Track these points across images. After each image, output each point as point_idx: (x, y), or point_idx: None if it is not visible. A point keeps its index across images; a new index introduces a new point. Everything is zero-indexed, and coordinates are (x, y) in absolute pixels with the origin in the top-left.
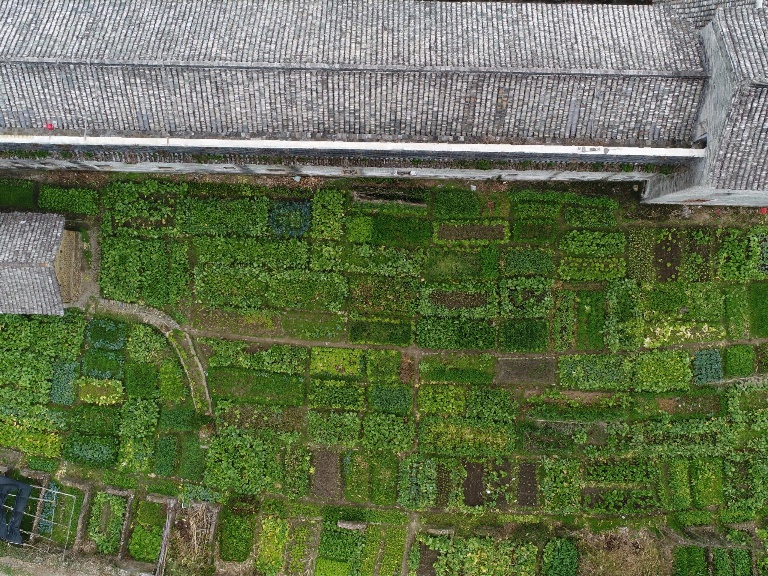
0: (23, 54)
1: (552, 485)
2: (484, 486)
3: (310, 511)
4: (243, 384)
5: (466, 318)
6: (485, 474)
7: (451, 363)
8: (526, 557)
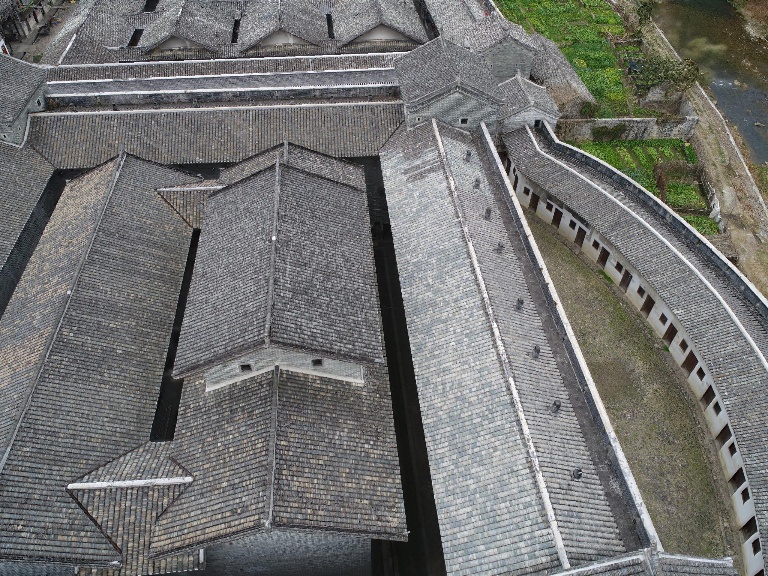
0: None
1: None
2: (561, 1)
3: None
4: (555, 36)
5: (505, 2)
6: (557, 1)
7: (522, 5)
8: None
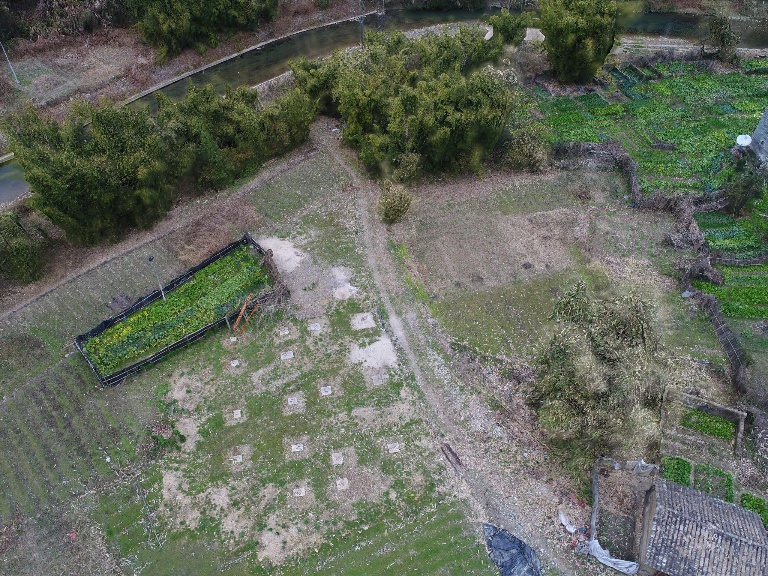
0: None
1: (765, 82)
2: None
3: None
4: None
5: None
6: None
7: None
8: (761, 66)
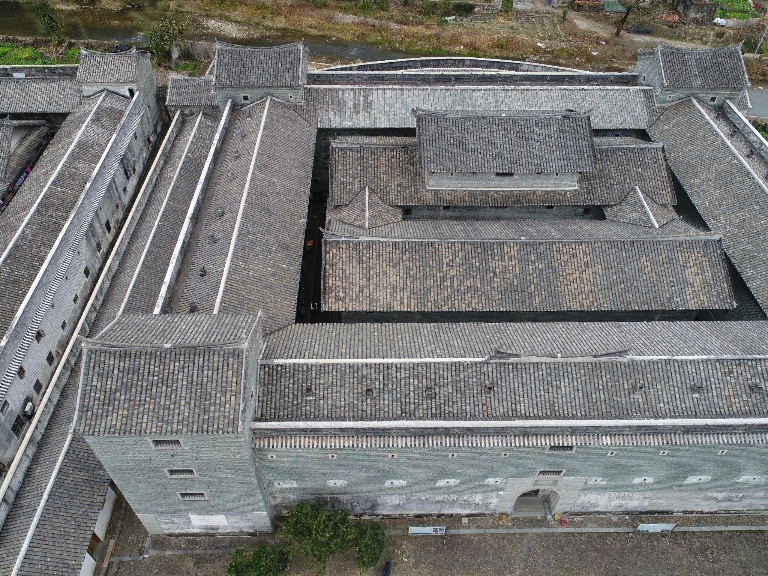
0: (3, 83)
1: None
2: None
3: (5, 58)
4: None
5: None
6: None
7: None
8: None
